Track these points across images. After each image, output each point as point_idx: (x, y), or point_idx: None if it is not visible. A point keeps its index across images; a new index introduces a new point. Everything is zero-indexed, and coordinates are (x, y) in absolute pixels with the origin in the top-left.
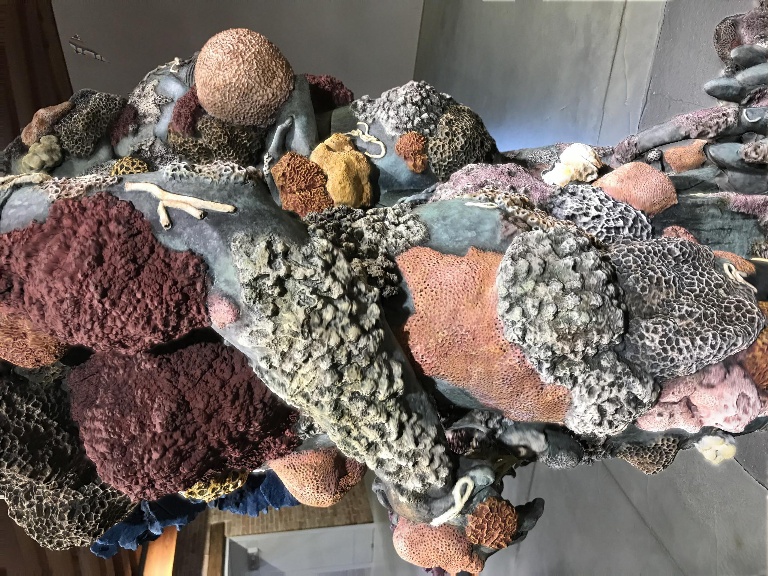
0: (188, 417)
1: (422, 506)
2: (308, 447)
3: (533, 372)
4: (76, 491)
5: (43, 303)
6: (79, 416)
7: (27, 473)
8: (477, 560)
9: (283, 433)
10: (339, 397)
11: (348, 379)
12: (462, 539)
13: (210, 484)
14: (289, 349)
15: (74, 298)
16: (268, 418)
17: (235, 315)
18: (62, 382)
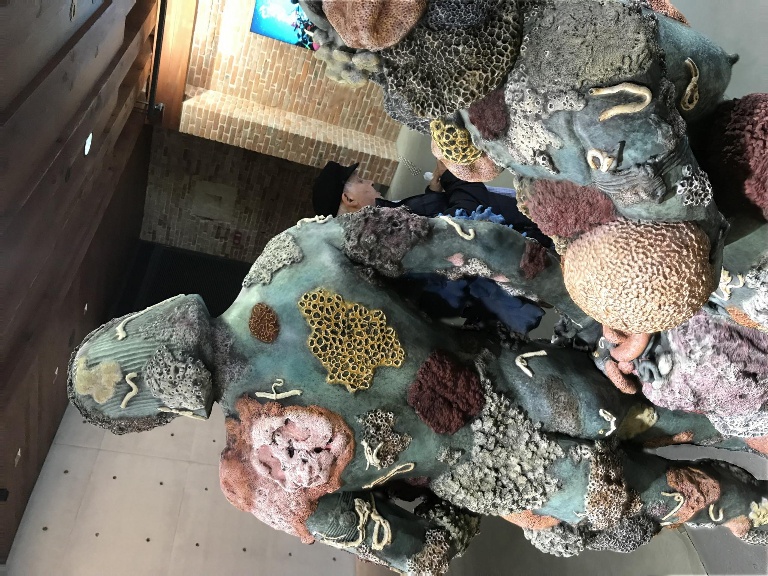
0: None
1: None
2: None
3: None
4: None
5: None
6: None
7: None
8: None
9: None
10: None
11: None
12: None
13: None
14: None
15: None
16: None
17: None
18: None
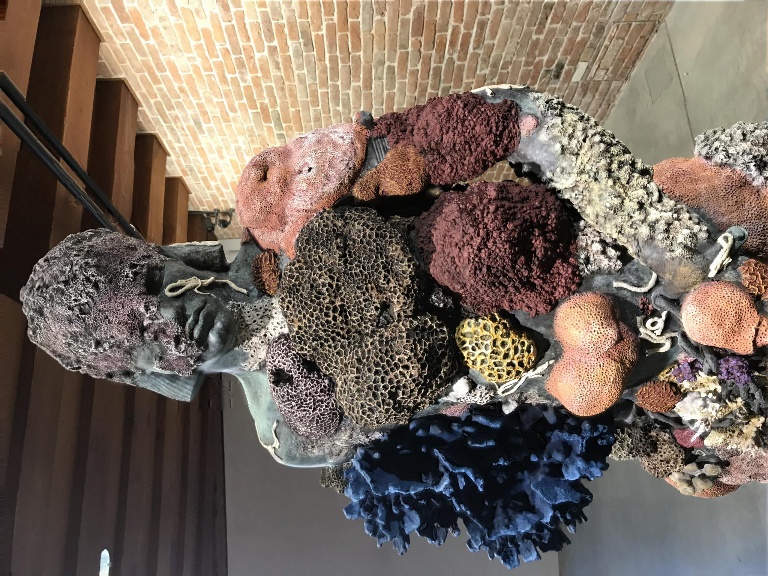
0: (509, 196)
1: (696, 258)
2: (587, 289)
3: (746, 183)
4: (412, 319)
5: (426, 128)
6: (429, 229)
7: (400, 246)
8: (766, 319)
9: (568, 261)
10: (610, 167)
11: (614, 149)
12: (743, 292)
13: (510, 335)
14: (573, 133)
15: (448, 111)
16: (559, 221)
17: (536, 122)
18: (410, 233)
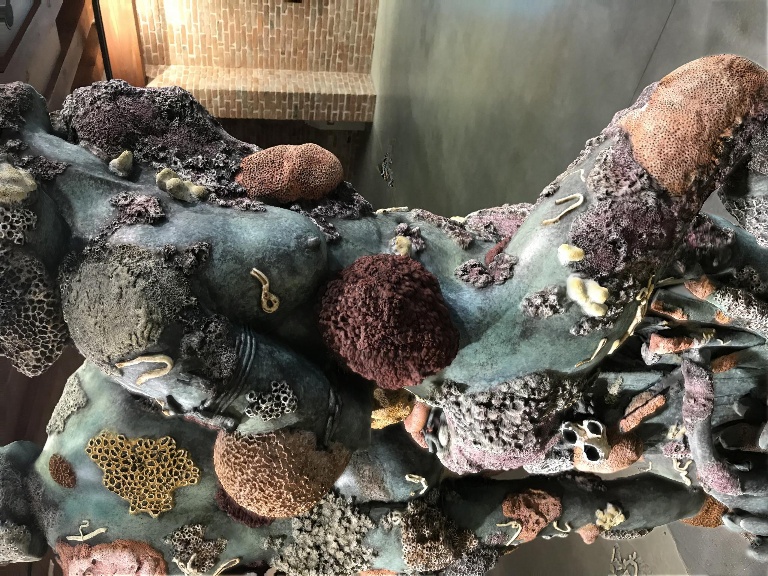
0: None
1: None
2: None
3: None
4: None
5: None
6: None
7: None
8: None
9: None
10: None
11: None
12: None
13: None
14: None
15: None
16: None
17: None
18: None
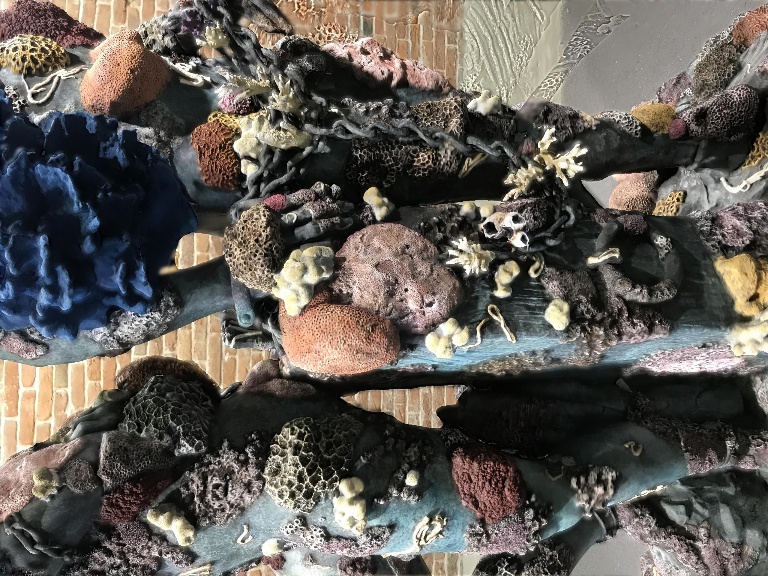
0: None
1: None
2: None
3: None
4: None
5: None
6: None
7: None
8: None
9: None
10: None
11: None
12: None
13: None
14: None
15: None
16: None
17: None
18: None
